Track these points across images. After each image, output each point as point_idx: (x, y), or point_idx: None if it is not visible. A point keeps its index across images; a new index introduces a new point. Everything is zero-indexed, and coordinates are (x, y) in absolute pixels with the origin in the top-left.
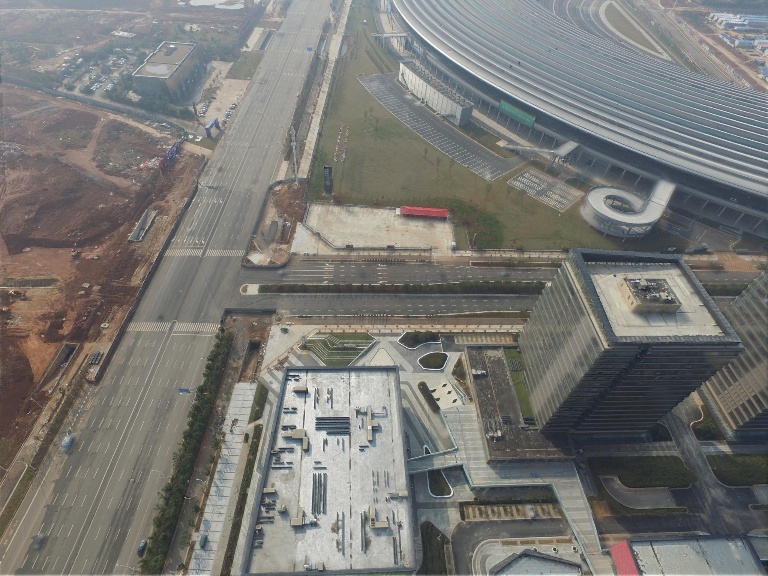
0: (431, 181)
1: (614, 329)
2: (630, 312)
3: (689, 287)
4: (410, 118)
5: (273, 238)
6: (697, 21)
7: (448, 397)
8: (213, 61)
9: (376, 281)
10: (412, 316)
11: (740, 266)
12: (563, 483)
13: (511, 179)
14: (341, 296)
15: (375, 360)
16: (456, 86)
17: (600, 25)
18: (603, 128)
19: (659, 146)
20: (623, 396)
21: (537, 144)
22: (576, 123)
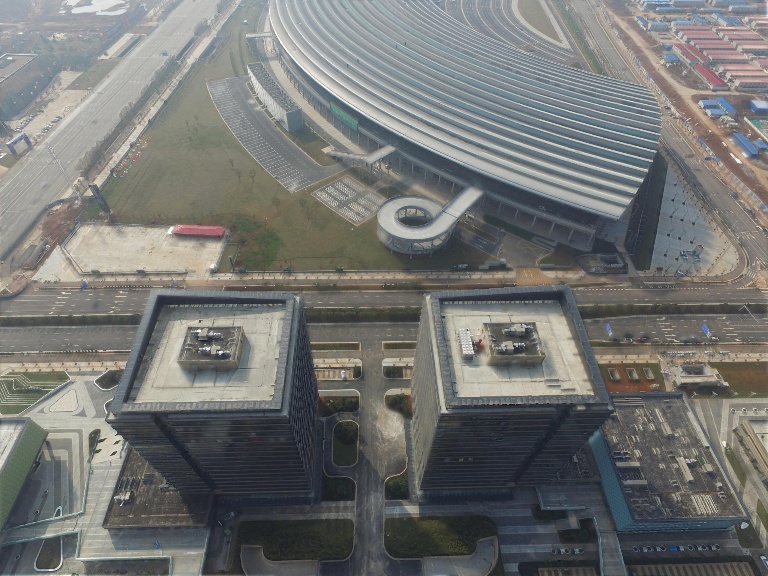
0: (227, 195)
1: (141, 392)
2: (180, 369)
3: (281, 334)
4: (240, 125)
5: (21, 264)
6: (619, 3)
7: (110, 448)
8: (62, 71)
9: (106, 311)
10: (125, 351)
11: None
12: (186, 556)
13: (317, 190)
14: (59, 329)
15: (57, 404)
16: (302, 88)
17: (507, 13)
18: (416, 131)
19: (467, 149)
20: (218, 461)
21: (366, 149)
22: (390, 126)
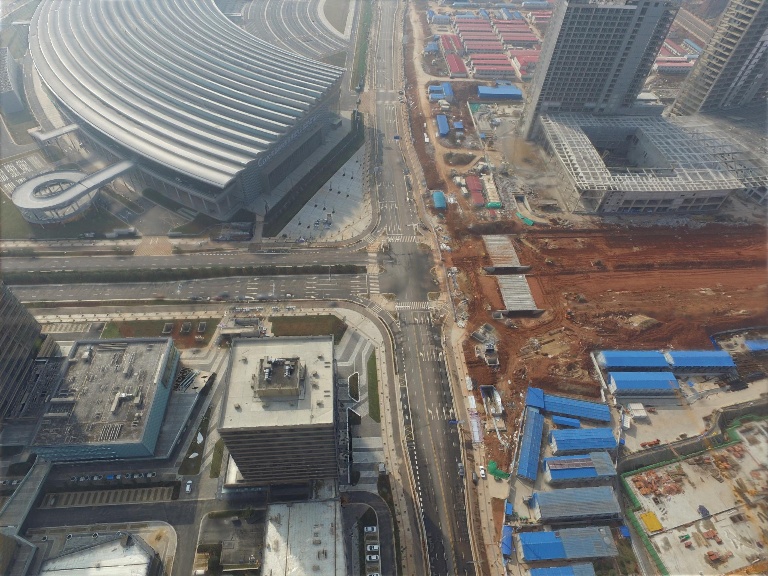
0: None
1: None
2: None
3: None
4: None
5: None
6: None
7: None
8: None
9: None
10: None
11: (156, 250)
12: None
13: None
14: None
15: None
16: None
17: (310, 6)
18: (90, 109)
19: (122, 125)
20: None
21: None
22: (70, 105)
